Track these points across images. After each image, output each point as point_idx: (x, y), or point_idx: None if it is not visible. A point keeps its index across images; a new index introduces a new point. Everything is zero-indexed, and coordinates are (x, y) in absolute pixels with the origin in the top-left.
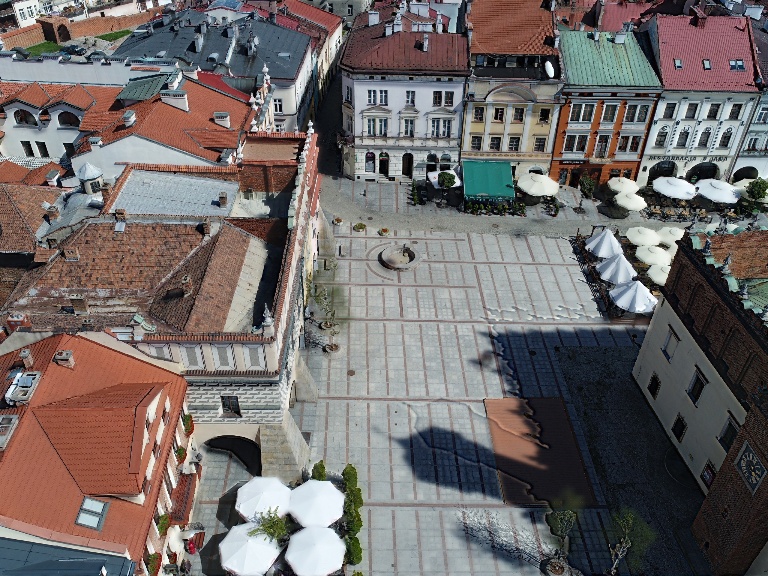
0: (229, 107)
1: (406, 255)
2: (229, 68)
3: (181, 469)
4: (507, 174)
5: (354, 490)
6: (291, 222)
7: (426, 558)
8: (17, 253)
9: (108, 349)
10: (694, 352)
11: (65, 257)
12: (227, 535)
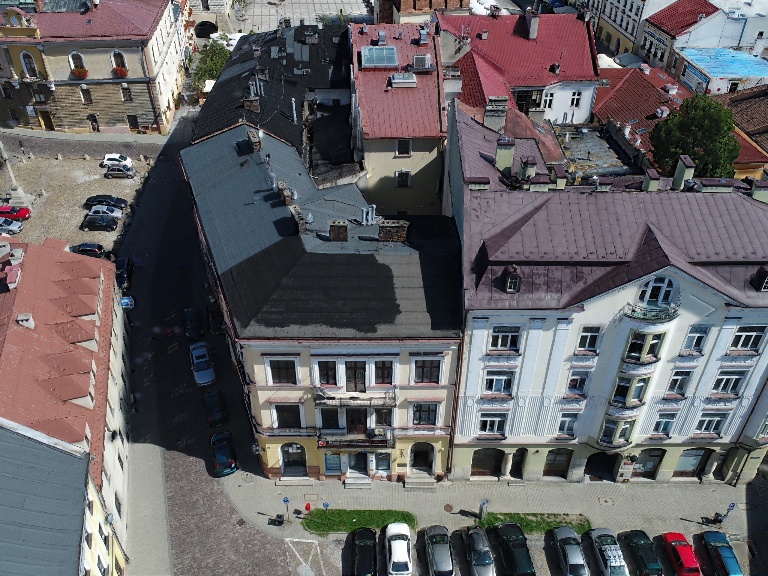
0: None
1: None
2: None
3: (189, 20)
4: None
5: None
6: None
7: None
8: None
9: None
10: None
11: None
12: None
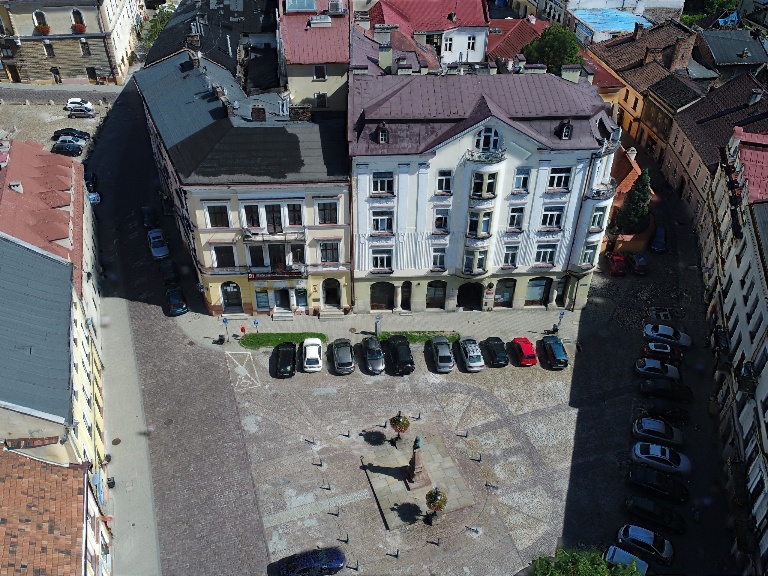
0: None
1: None
2: None
3: None
4: None
5: None
6: None
7: None
8: None
9: None
10: None
11: None
12: None
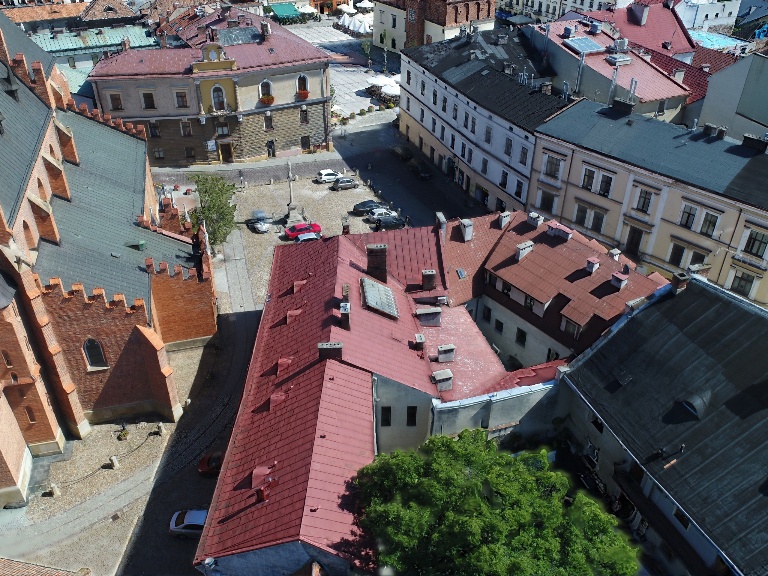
0: None
1: None
2: None
3: None
4: (293, 7)
5: None
6: None
7: None
8: (128, 17)
9: (208, 13)
10: (390, 11)
11: (157, 9)
12: None
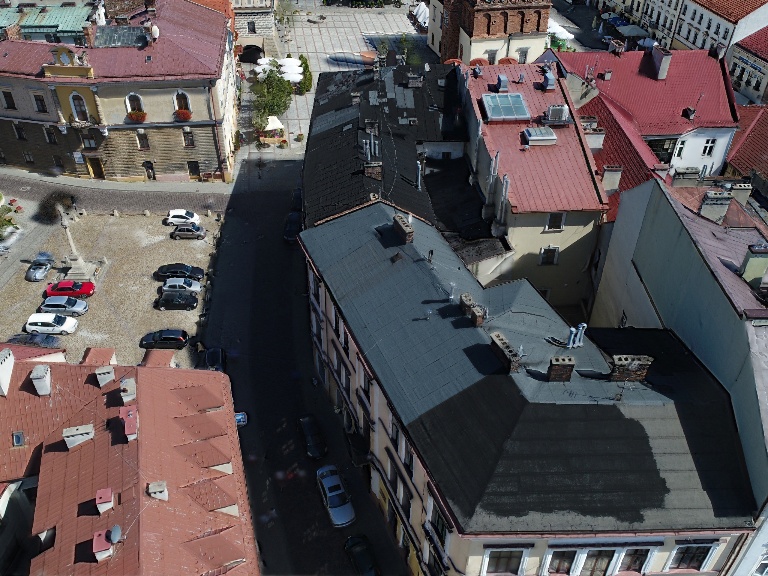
0: None
1: None
2: None
3: None
4: None
5: None
6: None
7: None
8: None
9: None
10: (440, 8)
11: None
12: None
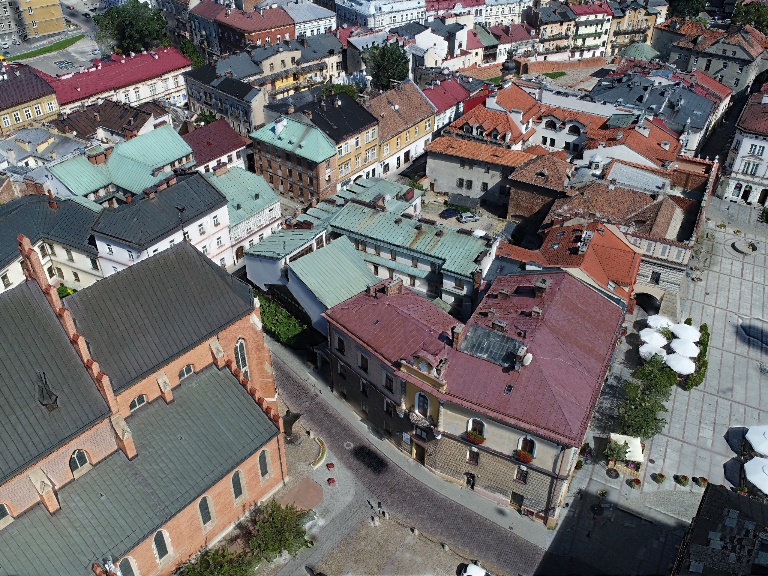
0: (667, 139)
1: (751, 248)
2: (666, 116)
3: None
4: None
5: (707, 332)
6: (704, 203)
7: (737, 373)
8: (555, 190)
9: (614, 234)
10: None
11: (583, 195)
12: (643, 330)
